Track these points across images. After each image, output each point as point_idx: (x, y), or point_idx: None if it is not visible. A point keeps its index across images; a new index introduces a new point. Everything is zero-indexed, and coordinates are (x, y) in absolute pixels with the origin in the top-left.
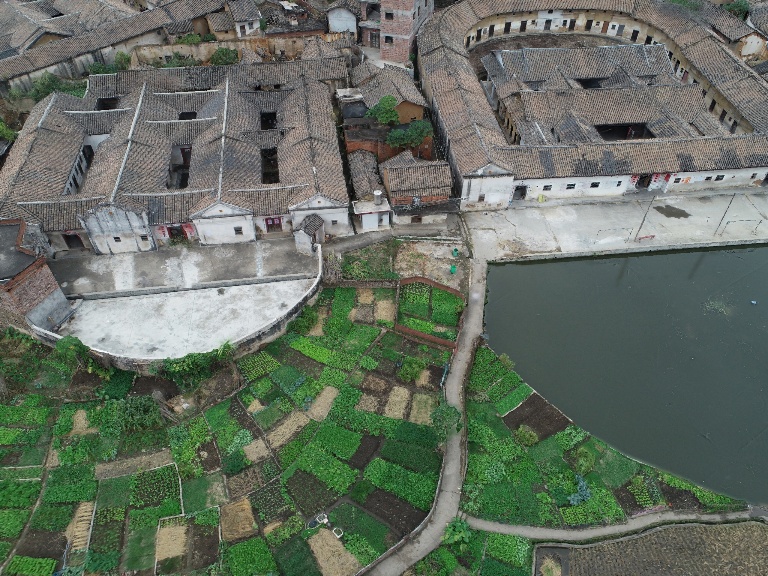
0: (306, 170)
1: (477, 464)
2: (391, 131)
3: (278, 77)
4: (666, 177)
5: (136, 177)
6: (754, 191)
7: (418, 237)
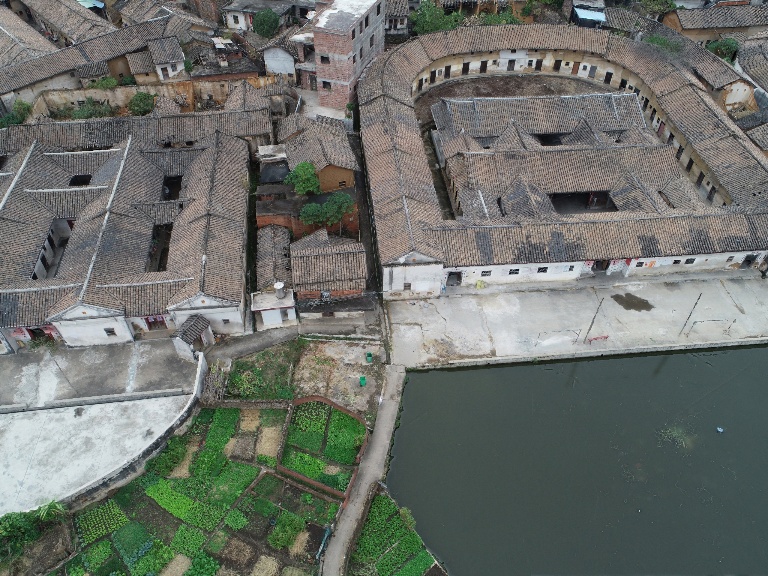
0: (195, 258)
1: None
2: (307, 204)
3: (191, 133)
4: (627, 260)
5: None
6: (731, 276)
7: (328, 335)
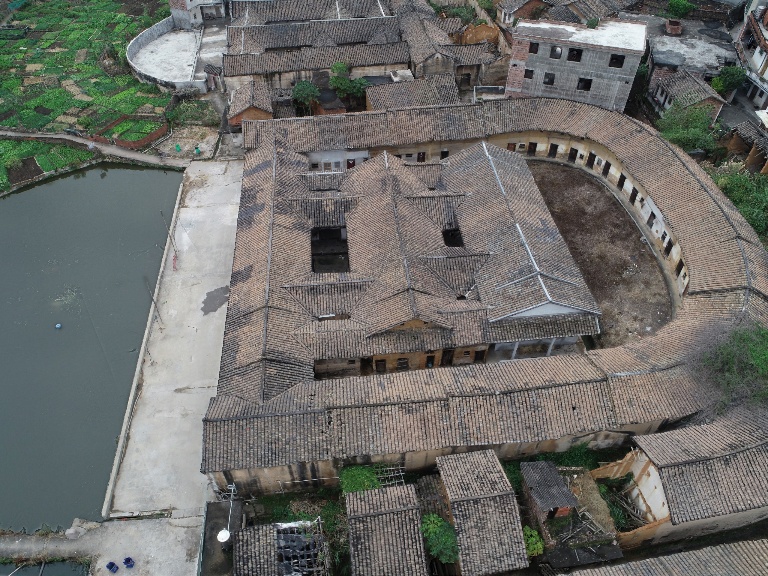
0: None
1: (8, 144)
2: None
3: (410, 36)
4: None
5: (269, 7)
6: None
7: None
